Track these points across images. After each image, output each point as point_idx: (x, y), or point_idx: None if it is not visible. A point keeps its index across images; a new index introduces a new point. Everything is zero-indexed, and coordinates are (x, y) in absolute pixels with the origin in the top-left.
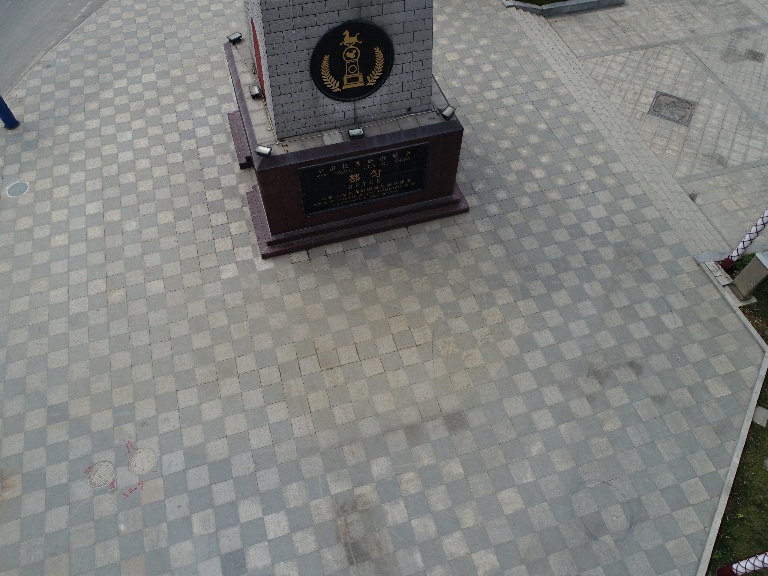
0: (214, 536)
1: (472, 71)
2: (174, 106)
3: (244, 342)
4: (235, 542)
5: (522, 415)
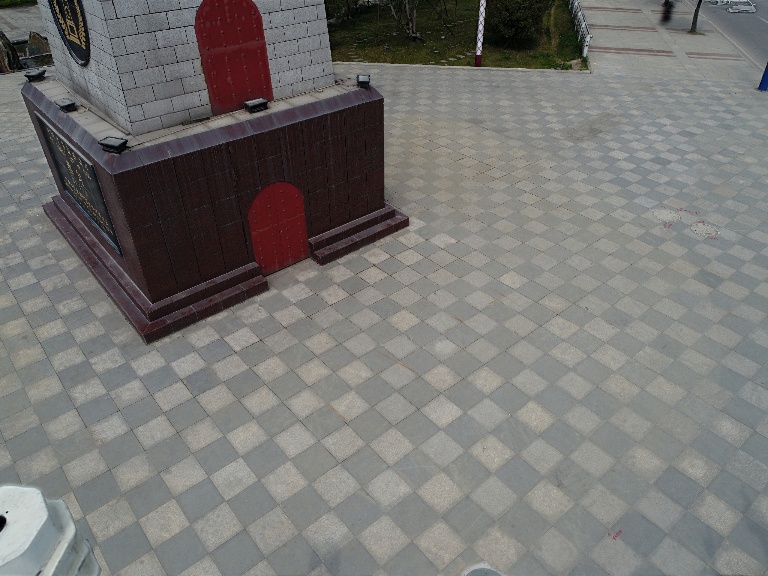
0: (659, 172)
1: (13, 177)
2: (109, 443)
3: (511, 206)
4: (650, 164)
5: (448, 106)
